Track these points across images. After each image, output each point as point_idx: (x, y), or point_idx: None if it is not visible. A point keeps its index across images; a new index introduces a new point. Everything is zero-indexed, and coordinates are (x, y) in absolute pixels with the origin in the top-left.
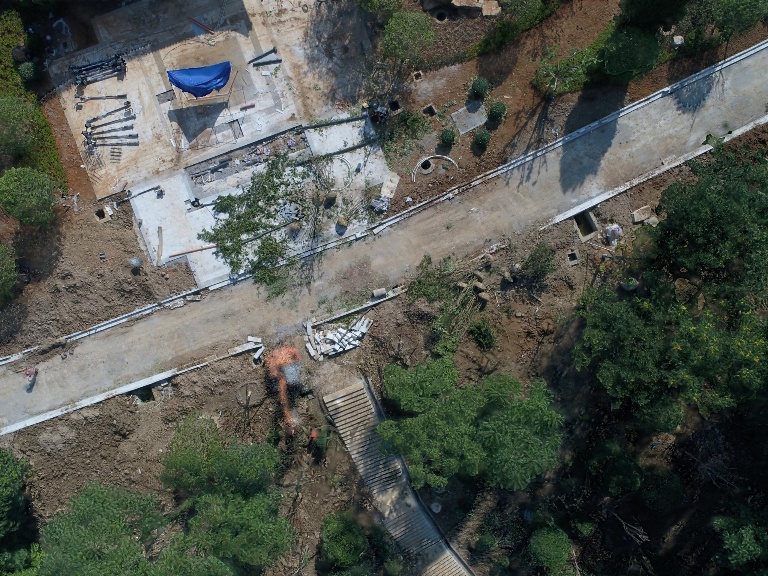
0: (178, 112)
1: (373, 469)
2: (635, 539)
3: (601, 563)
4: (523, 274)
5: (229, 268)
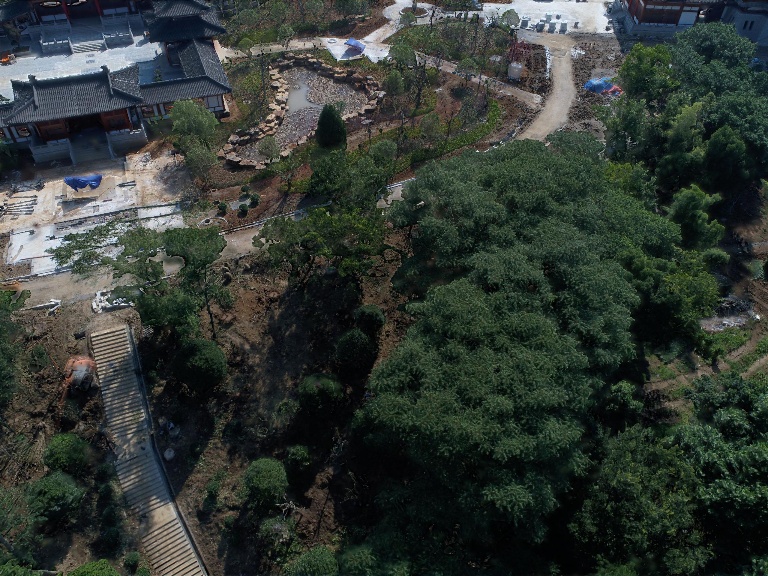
0: (64, 202)
1: (118, 409)
2: (335, 445)
3: (337, 545)
4: (256, 262)
5: None
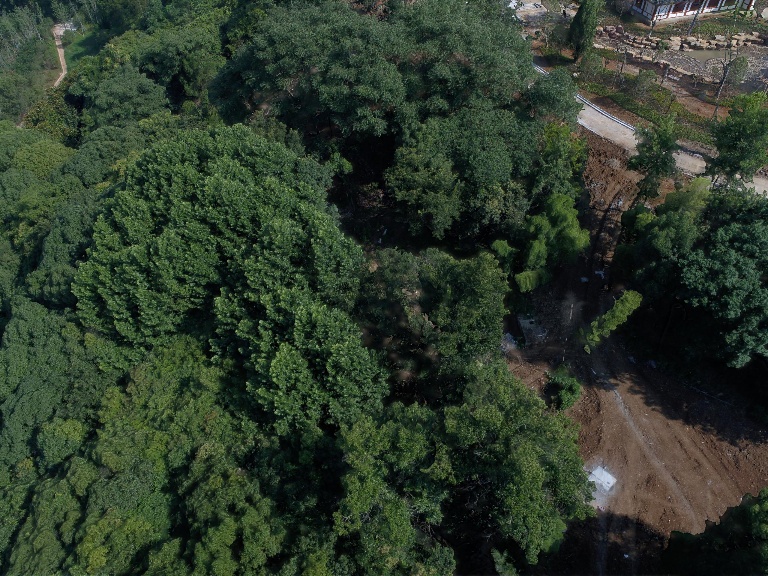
0: None
1: None
2: None
3: None
4: None
5: None
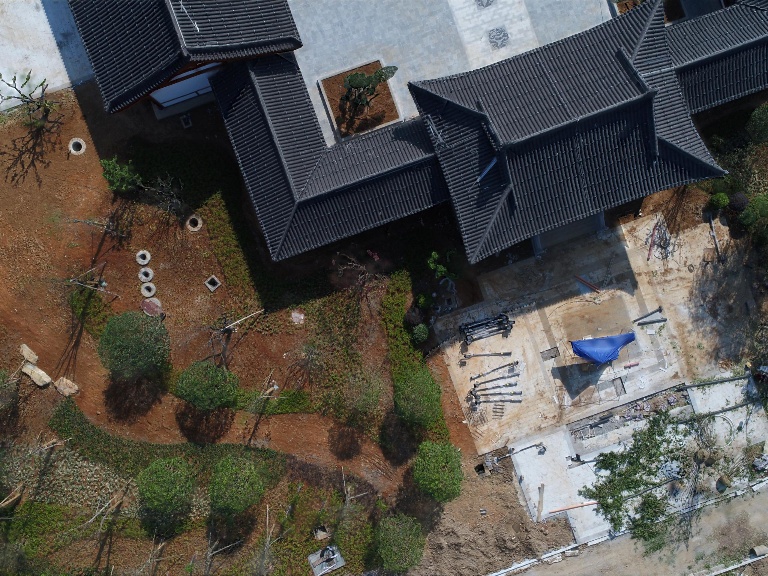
0: (562, 369)
1: None
2: None
3: None
4: None
5: (609, 524)
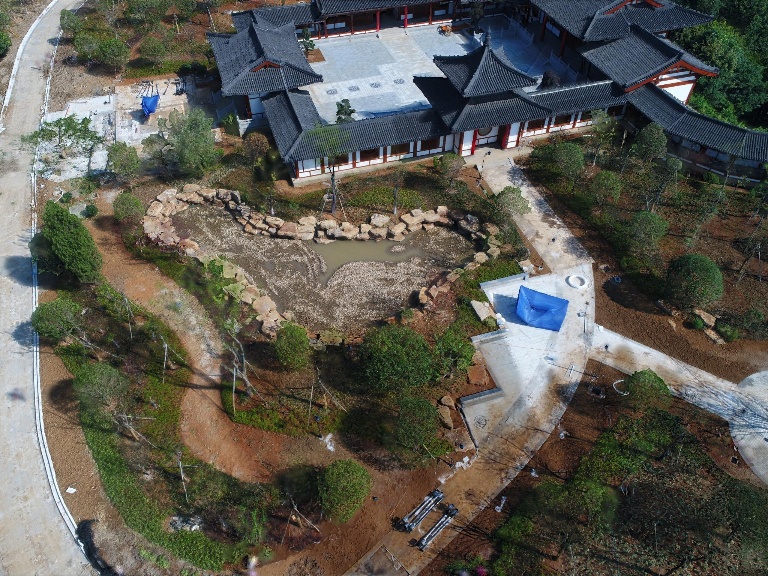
0: None
1: None
2: None
3: None
4: None
5: None
